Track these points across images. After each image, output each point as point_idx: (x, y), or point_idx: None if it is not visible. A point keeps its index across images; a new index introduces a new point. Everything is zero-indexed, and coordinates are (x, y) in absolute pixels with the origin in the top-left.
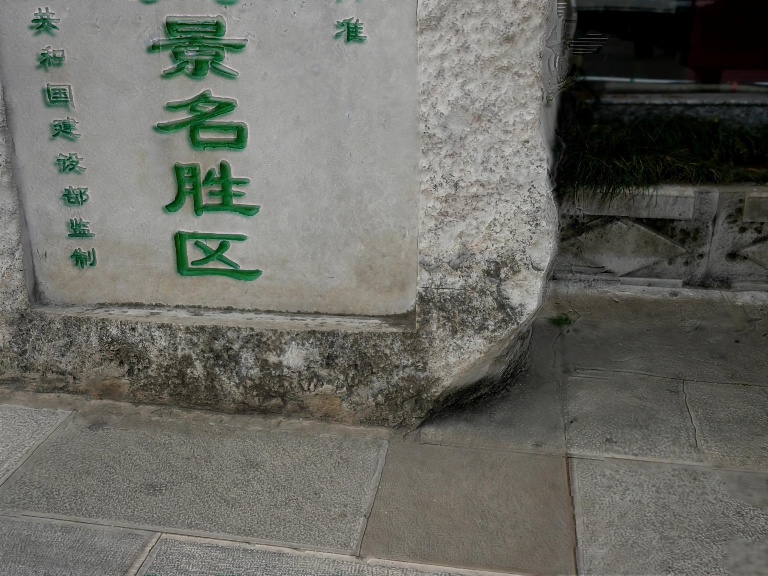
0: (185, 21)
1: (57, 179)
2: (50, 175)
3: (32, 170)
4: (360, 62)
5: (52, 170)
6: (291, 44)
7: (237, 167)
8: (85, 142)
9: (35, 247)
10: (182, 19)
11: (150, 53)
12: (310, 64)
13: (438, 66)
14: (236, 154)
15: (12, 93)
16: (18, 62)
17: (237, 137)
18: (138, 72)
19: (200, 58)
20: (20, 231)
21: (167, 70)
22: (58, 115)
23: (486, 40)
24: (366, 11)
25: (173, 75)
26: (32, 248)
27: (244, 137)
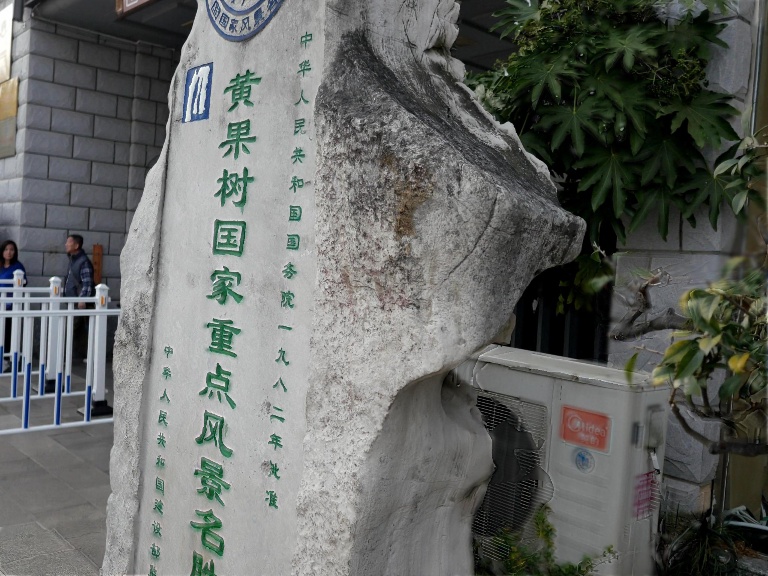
0: (209, 462)
1: (150, 536)
2: (148, 532)
3: (143, 526)
4: (273, 523)
5: (150, 529)
6: (246, 496)
7: (217, 568)
8: (164, 518)
9: (136, 575)
10: (208, 461)
11: (193, 476)
12: (253, 514)
13: (304, 545)
14: (217, 558)
15: (145, 476)
16: (149, 459)
17: (219, 547)
18: (188, 485)
19: (212, 488)
20: (128, 562)
21: (198, 489)
22: (157, 497)
23: (324, 538)
24: (279, 490)
25: (200, 494)
26: (135, 575)
27: (222, 548)
